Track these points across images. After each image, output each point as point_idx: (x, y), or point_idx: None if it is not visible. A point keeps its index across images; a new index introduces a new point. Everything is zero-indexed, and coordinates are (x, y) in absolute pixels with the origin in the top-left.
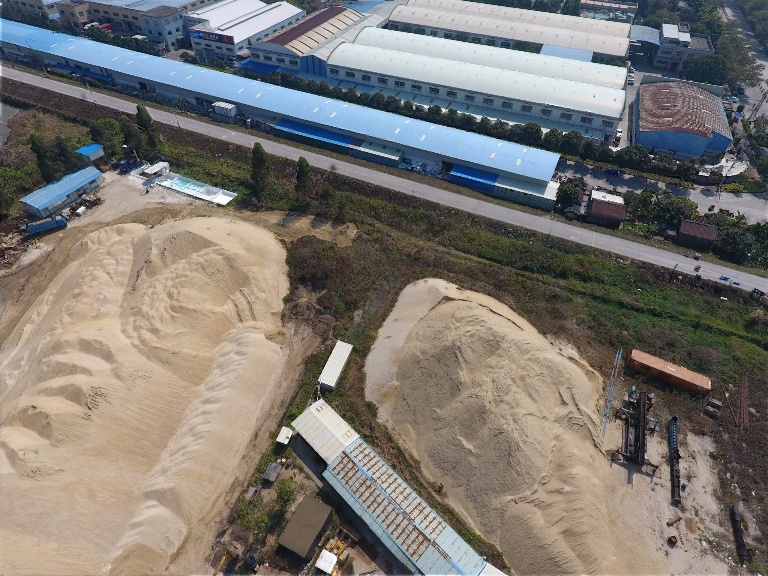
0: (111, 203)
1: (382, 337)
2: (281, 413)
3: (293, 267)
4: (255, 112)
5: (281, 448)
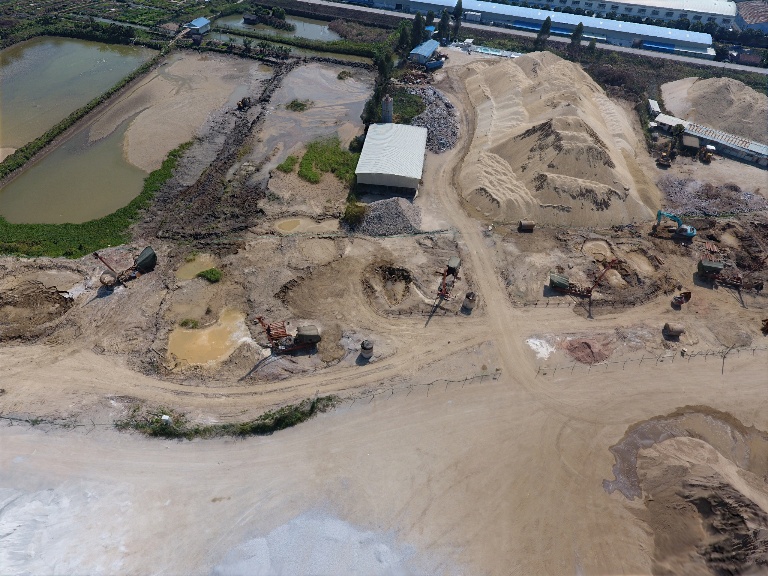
0: (454, 58)
1: (668, 99)
2: (639, 123)
3: (596, 77)
4: (493, 18)
5: (651, 131)
